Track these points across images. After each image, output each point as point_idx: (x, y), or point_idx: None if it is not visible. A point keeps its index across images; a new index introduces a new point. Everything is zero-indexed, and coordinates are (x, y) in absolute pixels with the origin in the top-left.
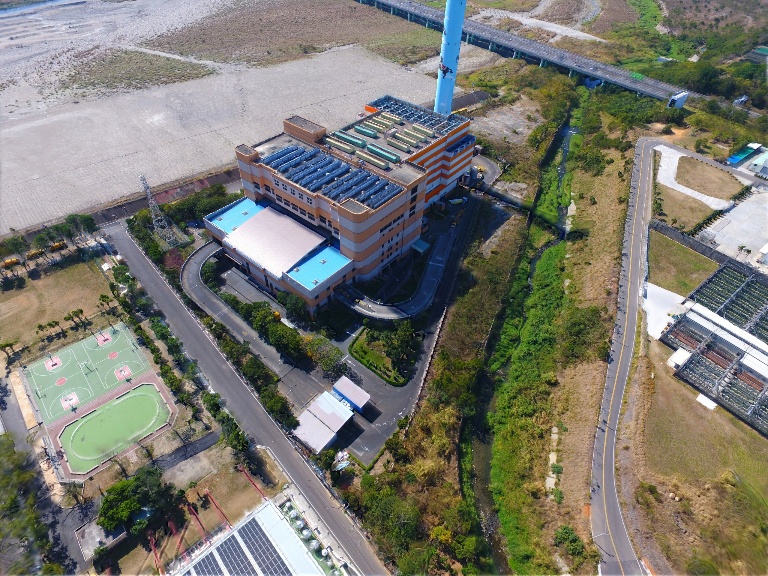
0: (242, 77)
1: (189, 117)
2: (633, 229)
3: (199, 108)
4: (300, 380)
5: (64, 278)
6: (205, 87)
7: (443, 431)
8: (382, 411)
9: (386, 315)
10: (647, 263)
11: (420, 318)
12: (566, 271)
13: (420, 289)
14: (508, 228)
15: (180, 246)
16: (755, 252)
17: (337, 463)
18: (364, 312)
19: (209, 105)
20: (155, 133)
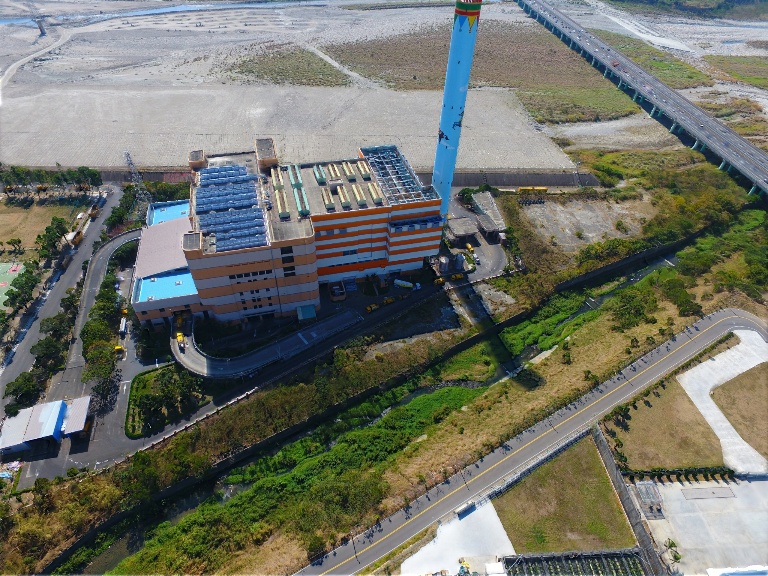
0: (364, 94)
1: (280, 117)
2: (562, 421)
3: (297, 112)
4: (75, 379)
5: (51, 212)
6: (324, 95)
7: (87, 506)
8: (89, 450)
9: (189, 362)
10: (518, 476)
11: (212, 383)
12: (438, 425)
13: (253, 355)
14: (430, 339)
15: (142, 221)
16: (716, 567)
17: (5, 470)
18: (175, 348)
19: (308, 111)
20: (241, 123)
